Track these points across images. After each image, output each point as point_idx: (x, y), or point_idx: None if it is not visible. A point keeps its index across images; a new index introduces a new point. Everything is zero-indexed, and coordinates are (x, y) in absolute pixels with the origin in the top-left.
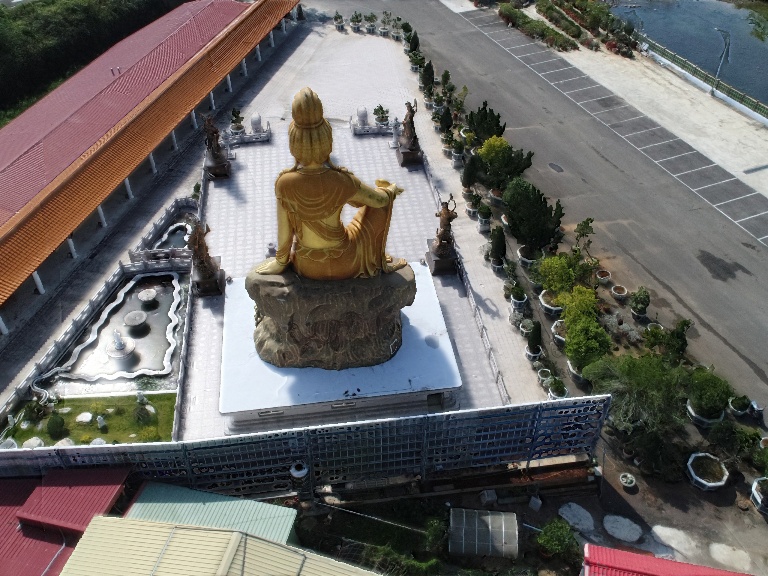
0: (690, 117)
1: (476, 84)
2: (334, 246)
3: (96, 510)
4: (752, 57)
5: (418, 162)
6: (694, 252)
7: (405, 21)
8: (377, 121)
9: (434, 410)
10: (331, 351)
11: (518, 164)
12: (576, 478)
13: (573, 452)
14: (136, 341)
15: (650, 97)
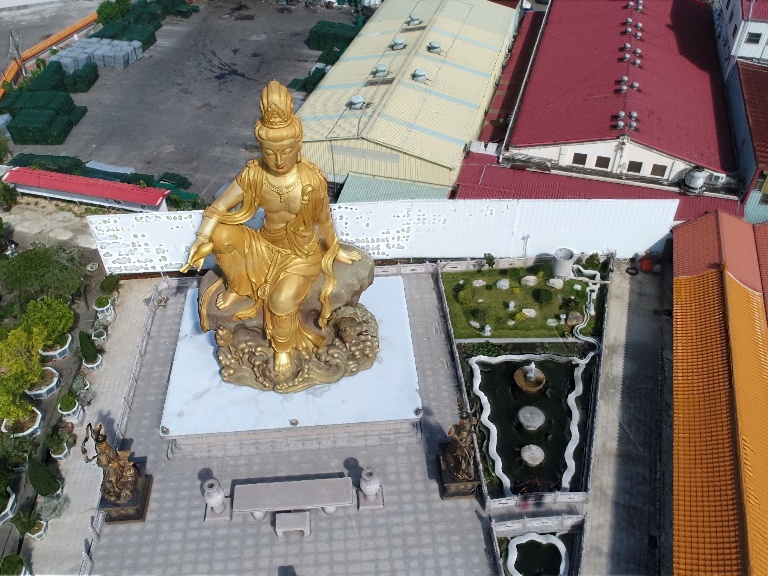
0: None
1: None
2: None
3: (464, 193)
4: None
5: None
6: None
7: None
8: None
9: None
10: None
11: None
12: None
13: None
14: None
15: None
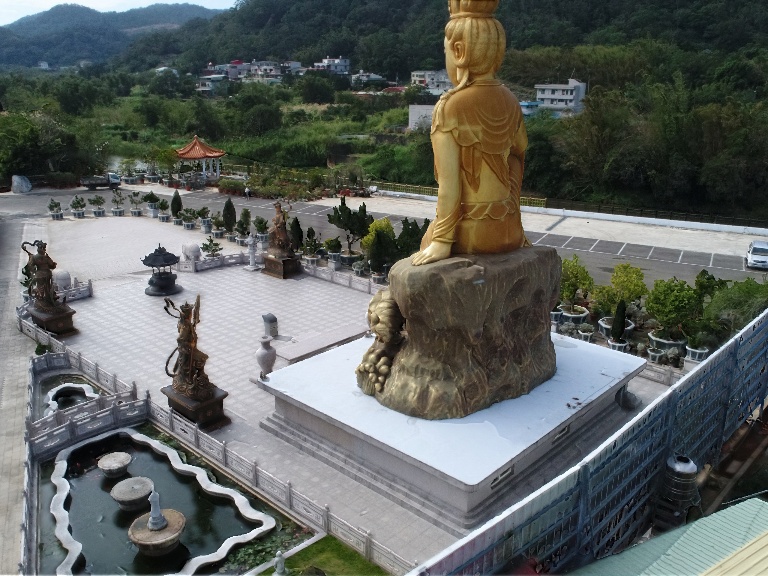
0: None
1: None
2: (508, 197)
3: None
4: None
5: (298, 272)
6: (596, 269)
7: (143, 195)
8: (210, 257)
9: None
10: (515, 366)
11: (417, 235)
12: None
13: None
14: None
15: (419, 211)
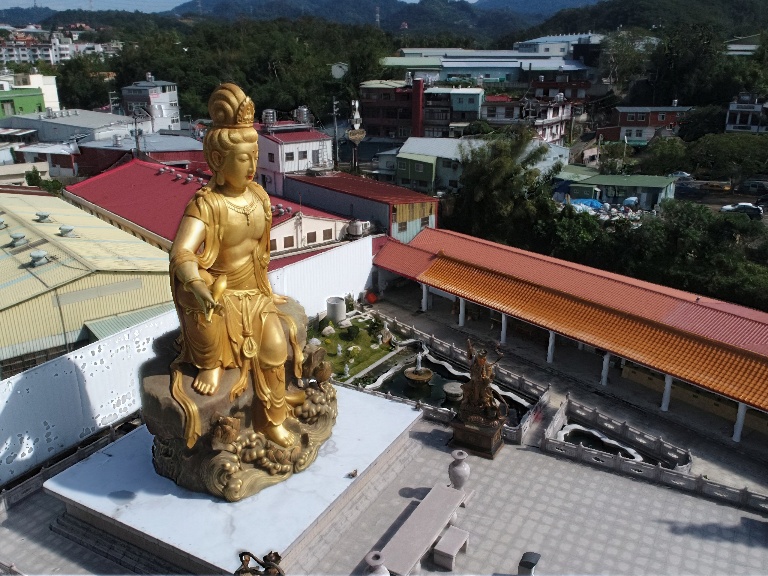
0: None
1: None
2: None
3: None
4: None
5: None
6: None
7: None
8: None
9: None
10: None
11: None
12: None
13: None
14: (441, 402)
15: None
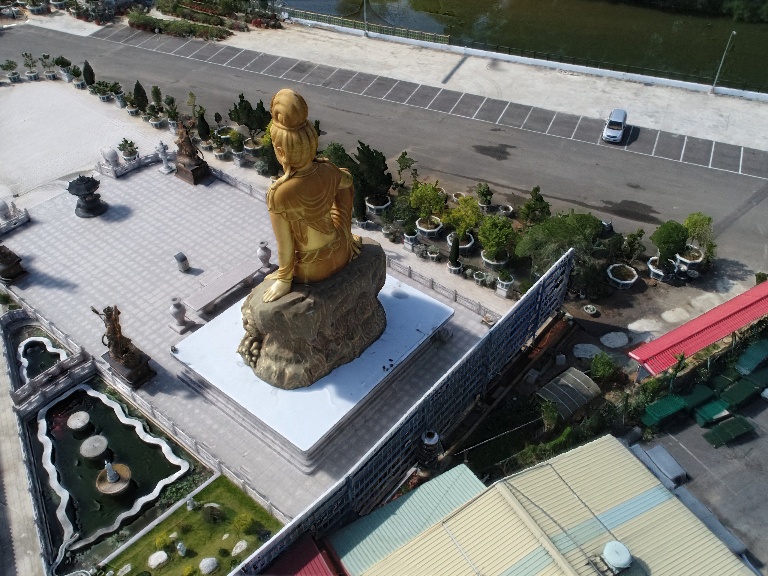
0: (370, 58)
1: (178, 92)
2: (333, 238)
3: None
4: (338, 6)
5: (207, 175)
6: (471, 149)
7: (54, 57)
8: (127, 156)
9: (437, 346)
10: (348, 343)
11: None
12: (563, 329)
13: (547, 314)
14: None
15: (327, 53)
